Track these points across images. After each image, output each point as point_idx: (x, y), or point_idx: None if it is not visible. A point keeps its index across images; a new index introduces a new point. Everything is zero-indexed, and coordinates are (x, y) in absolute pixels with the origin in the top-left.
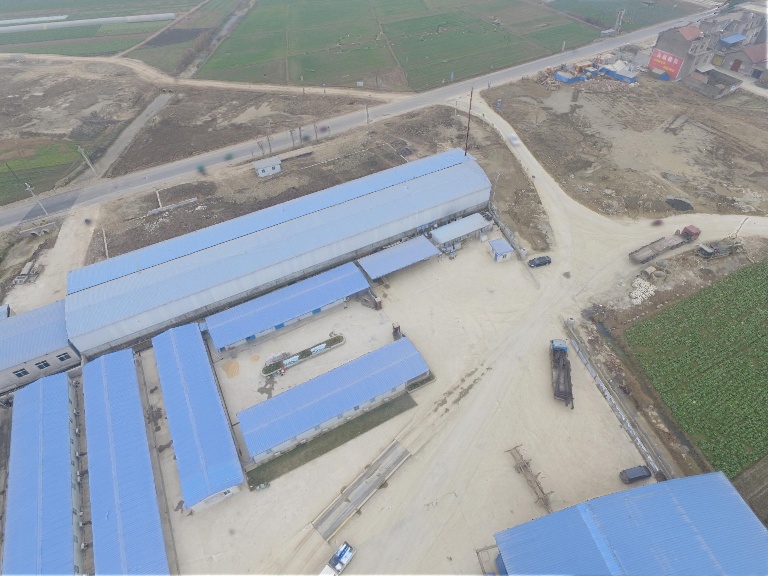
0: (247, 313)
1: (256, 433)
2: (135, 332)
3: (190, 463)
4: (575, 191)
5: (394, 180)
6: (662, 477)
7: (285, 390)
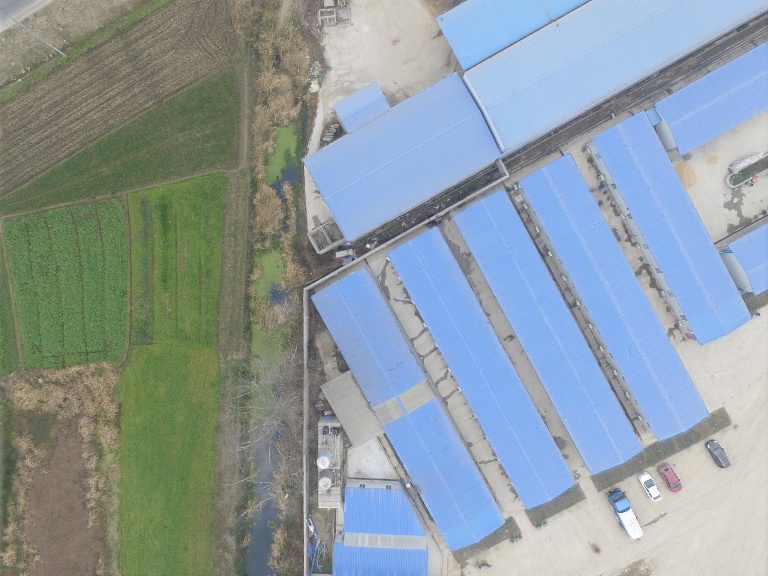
0: (718, 98)
1: (761, 271)
2: (558, 124)
3: (695, 302)
4: None
5: None
6: None
7: (757, 205)
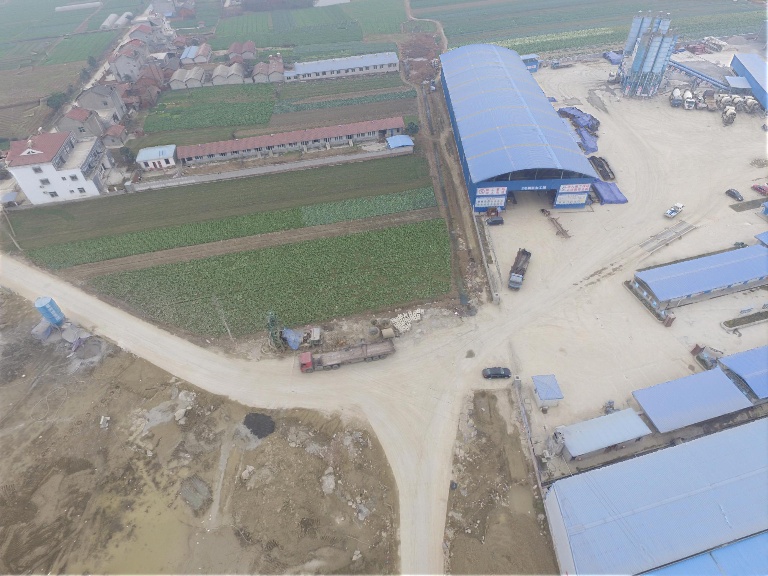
0: None
1: (765, 252)
2: None
3: None
4: (380, 502)
5: (761, 560)
6: (479, 222)
7: (760, 295)
